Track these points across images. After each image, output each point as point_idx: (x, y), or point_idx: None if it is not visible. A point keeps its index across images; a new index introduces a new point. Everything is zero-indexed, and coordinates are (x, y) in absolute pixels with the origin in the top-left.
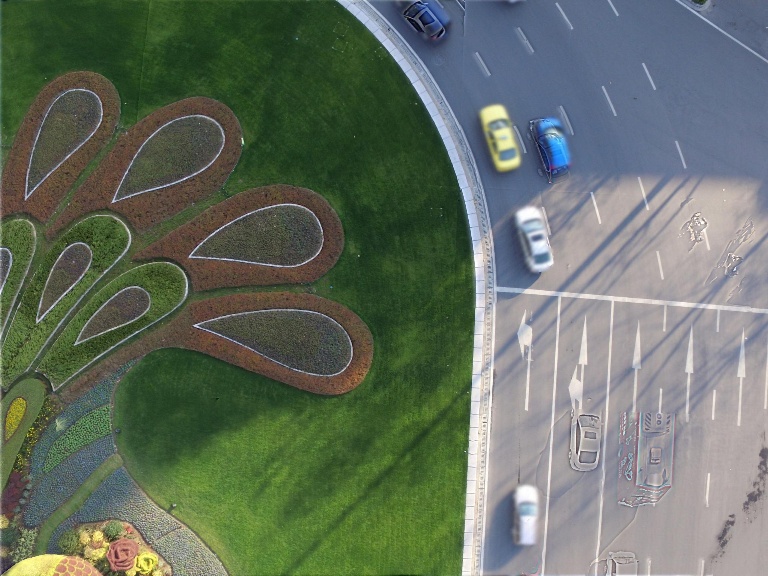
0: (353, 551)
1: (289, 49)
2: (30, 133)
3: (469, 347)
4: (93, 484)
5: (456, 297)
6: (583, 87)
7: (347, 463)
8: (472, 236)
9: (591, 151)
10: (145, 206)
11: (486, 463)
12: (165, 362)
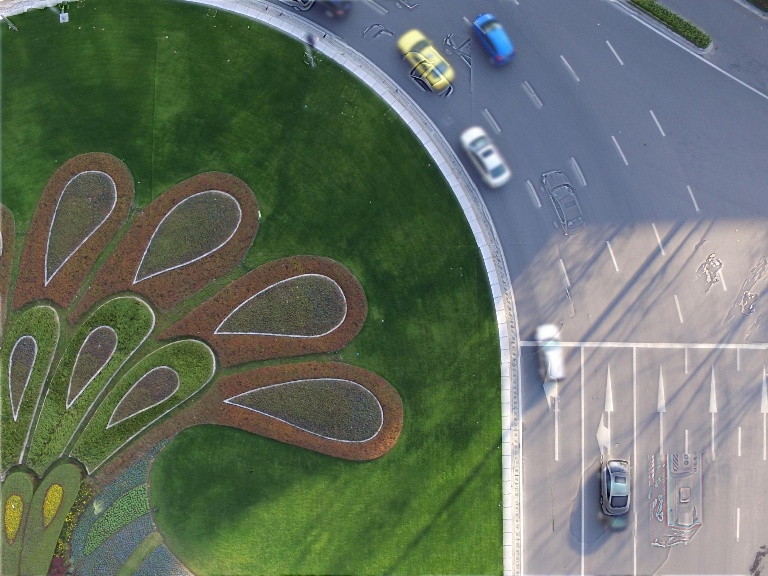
0: None
1: (299, 117)
2: (45, 218)
3: (497, 403)
4: (135, 563)
5: (481, 355)
6: (593, 137)
7: (385, 525)
8: (493, 293)
9: (604, 200)
10: (167, 286)
11: (520, 514)
12: (198, 439)
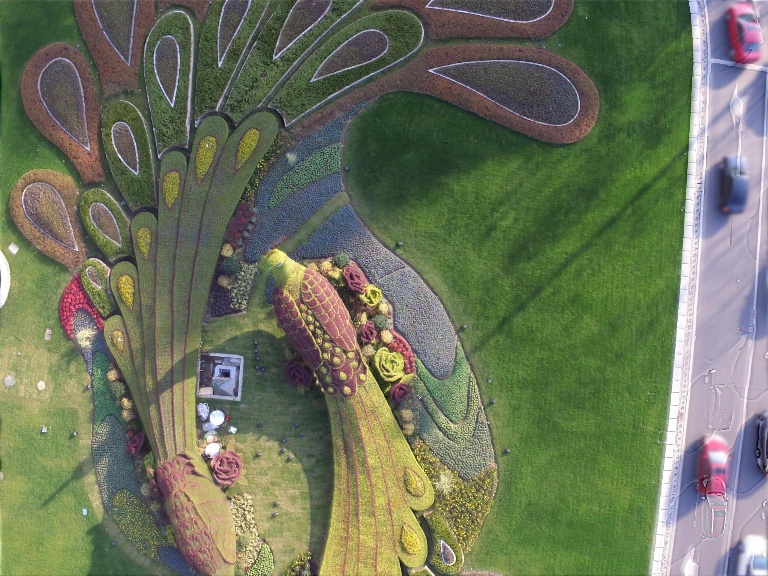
0: (574, 299)
1: None
2: None
3: (687, 111)
4: (318, 220)
5: (676, 63)
6: None
7: (571, 212)
8: (691, 9)
9: None
10: None
11: (700, 224)
12: (398, 104)
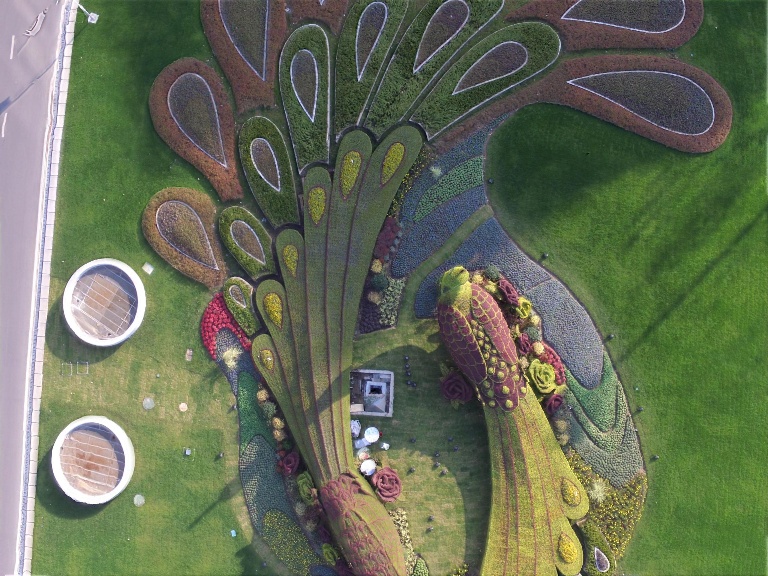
0: (715, 306)
1: None
2: None
3: None
4: (464, 234)
5: None
6: None
7: (710, 220)
8: None
9: None
10: None
11: None
12: (538, 116)
